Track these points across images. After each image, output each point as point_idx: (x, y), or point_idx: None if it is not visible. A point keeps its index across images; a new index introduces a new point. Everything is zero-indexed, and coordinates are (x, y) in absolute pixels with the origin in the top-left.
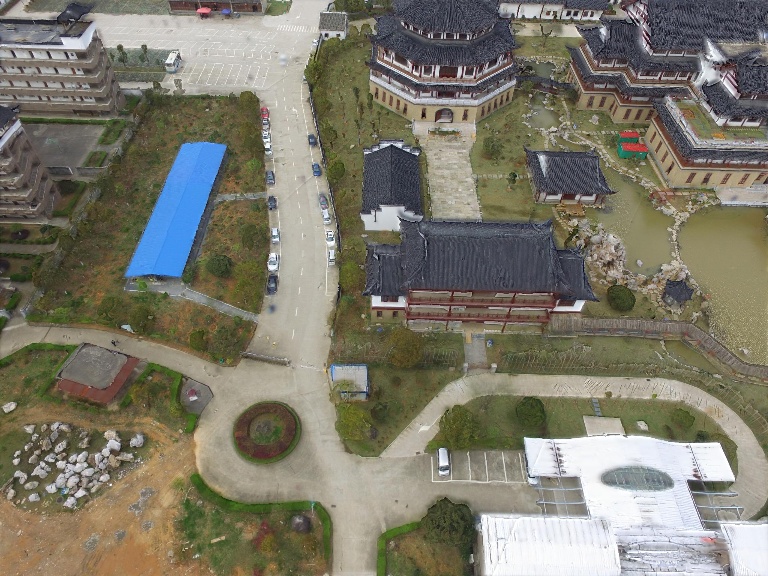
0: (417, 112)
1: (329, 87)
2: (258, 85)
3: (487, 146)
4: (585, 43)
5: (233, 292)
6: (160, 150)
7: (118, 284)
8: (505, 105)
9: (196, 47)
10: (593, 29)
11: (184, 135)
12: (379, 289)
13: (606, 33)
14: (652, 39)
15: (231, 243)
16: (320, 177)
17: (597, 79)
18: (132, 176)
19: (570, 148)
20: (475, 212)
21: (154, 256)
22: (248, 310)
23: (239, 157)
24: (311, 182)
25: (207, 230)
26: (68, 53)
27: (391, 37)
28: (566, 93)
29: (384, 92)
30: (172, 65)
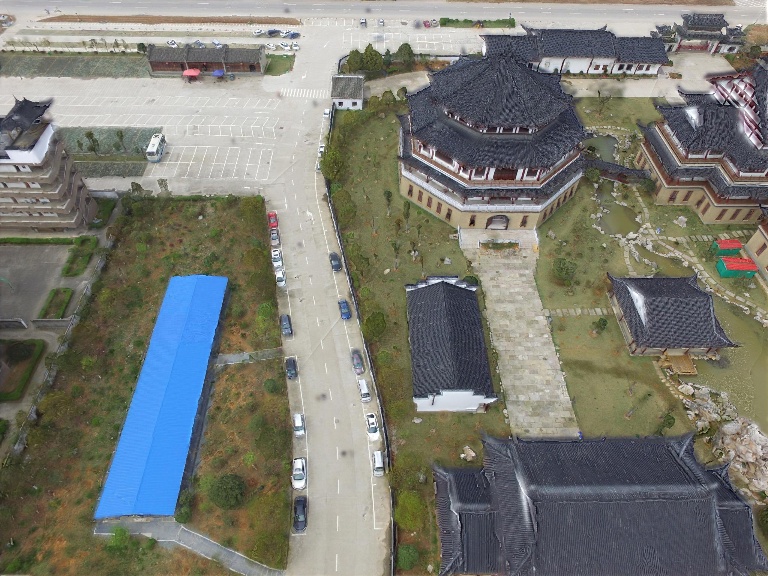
0: (464, 219)
1: (351, 182)
2: (262, 177)
3: (559, 270)
4: (645, 106)
5: (246, 530)
6: (142, 284)
7: (86, 523)
8: (567, 200)
9: (184, 123)
10: (677, 109)
11: (172, 258)
12: (463, 566)
13: (696, 116)
14: (764, 131)
15: (240, 440)
16: (350, 320)
17: (686, 173)
18: (105, 328)
19: (658, 265)
20: (556, 372)
21: (135, 480)
22: (269, 564)
23: (244, 291)
24: (339, 328)
25: (207, 418)
26: (18, 165)
27: (431, 128)
28: (642, 185)
29: (421, 191)
30: (155, 154)
